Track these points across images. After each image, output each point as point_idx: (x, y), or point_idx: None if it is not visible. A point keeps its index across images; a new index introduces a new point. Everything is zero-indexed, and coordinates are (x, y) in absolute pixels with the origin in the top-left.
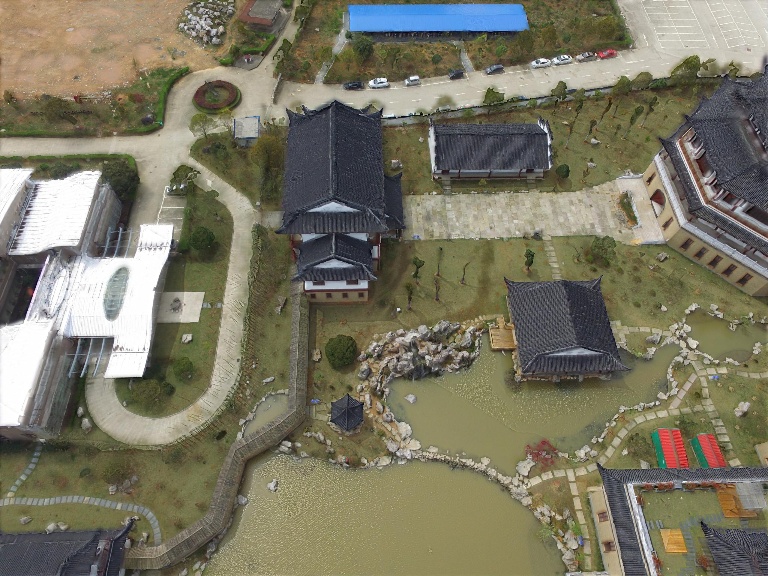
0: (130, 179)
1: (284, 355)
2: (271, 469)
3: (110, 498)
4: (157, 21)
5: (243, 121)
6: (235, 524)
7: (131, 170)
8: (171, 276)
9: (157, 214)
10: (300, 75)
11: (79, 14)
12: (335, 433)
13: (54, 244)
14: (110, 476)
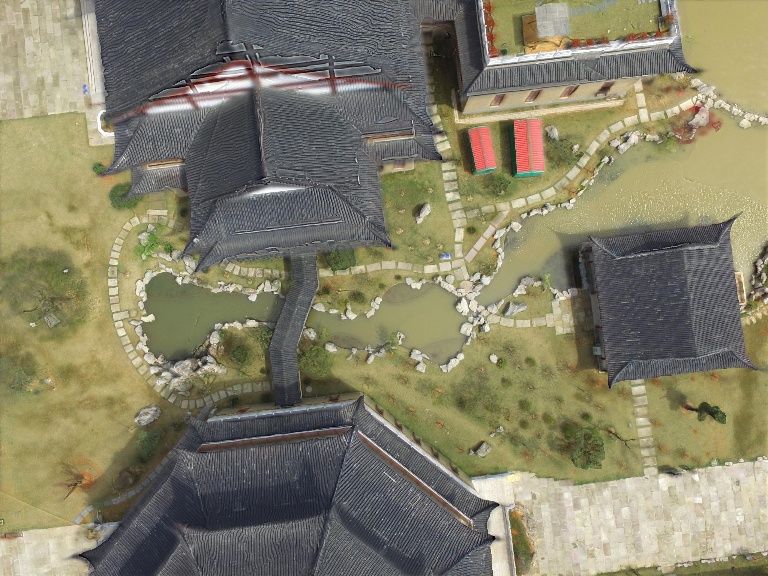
0: None
1: None
2: None
3: None
4: None
5: None
6: None
7: None
8: None
9: None
10: None
11: None
12: None
13: None
14: None
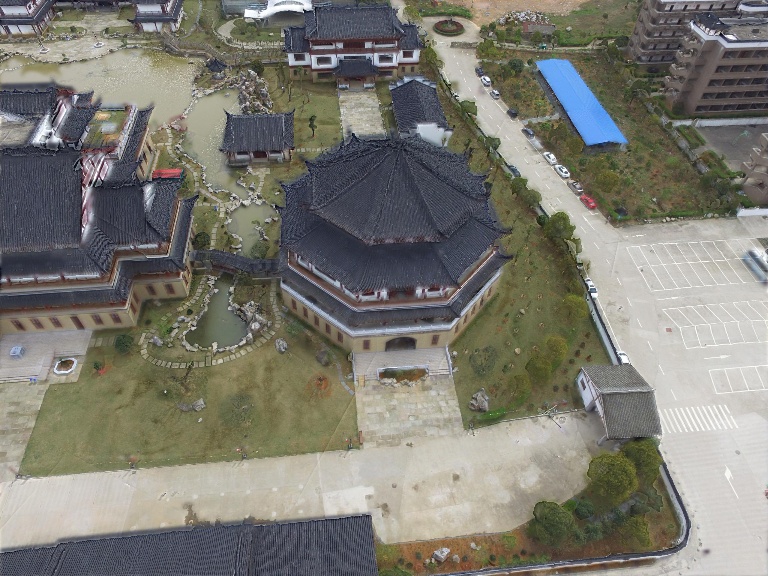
0: None
1: None
2: None
3: None
4: (515, 5)
5: (422, 30)
6: None
7: (369, 1)
8: None
9: None
10: (480, 51)
11: None
12: None
13: None
14: None
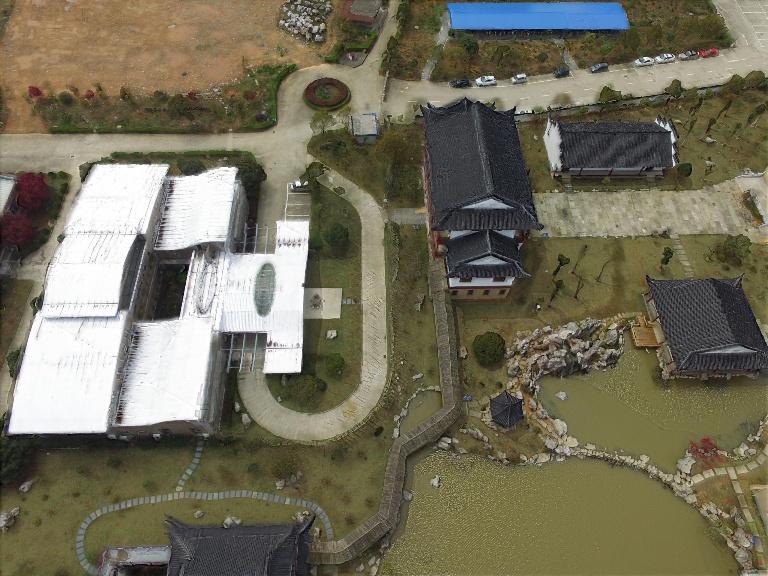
0: (258, 175)
1: (430, 352)
2: (430, 465)
3: (278, 493)
4: (256, 18)
5: (360, 118)
6: (403, 520)
7: (259, 166)
8: (306, 272)
9: (284, 210)
10: (407, 73)
11: (178, 11)
12: (491, 430)
13: (203, 240)
14: (282, 471)
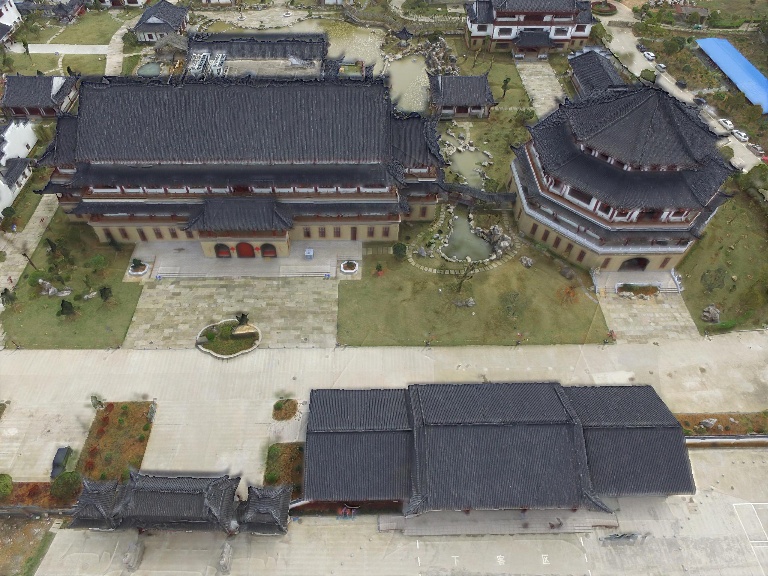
0: None
1: None
2: None
3: None
4: None
5: None
6: None
7: None
8: None
9: None
10: (638, 29)
11: None
12: None
13: None
14: None
